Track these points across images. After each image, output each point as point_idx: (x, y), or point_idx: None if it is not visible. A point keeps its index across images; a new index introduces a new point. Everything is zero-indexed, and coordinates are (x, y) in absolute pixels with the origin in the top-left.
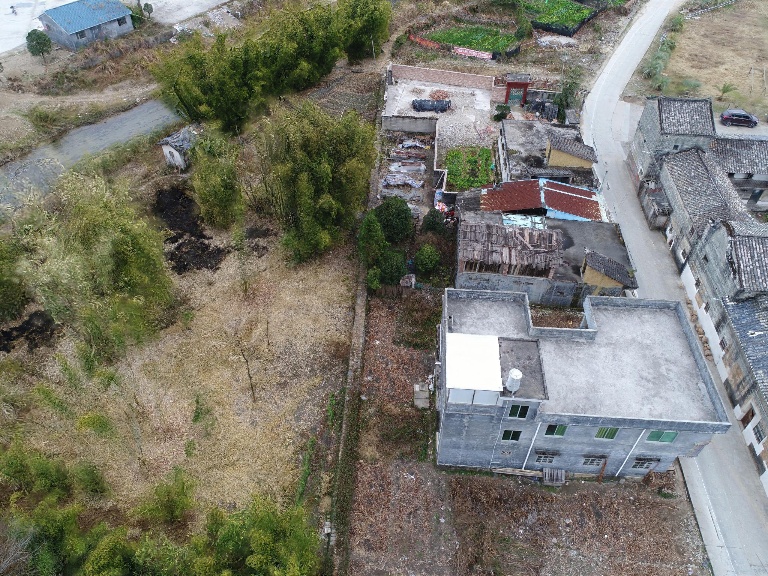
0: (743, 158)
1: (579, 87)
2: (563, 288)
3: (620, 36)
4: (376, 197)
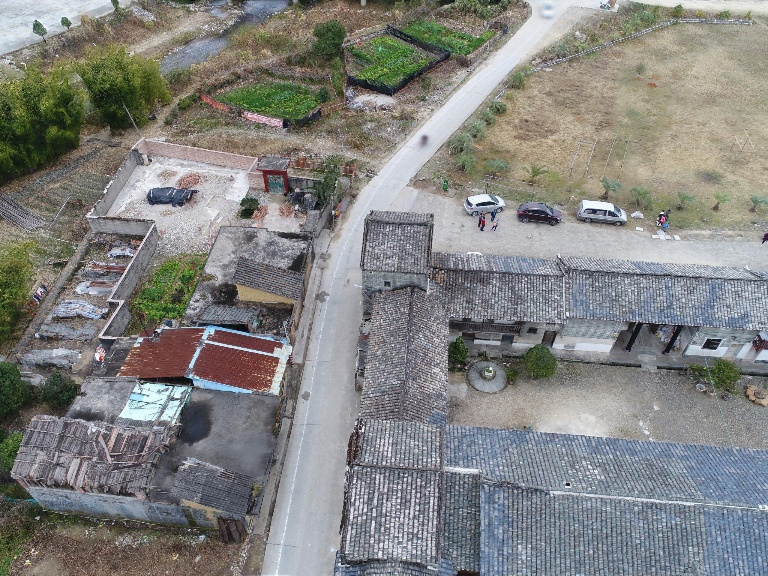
0: (476, 297)
1: (333, 179)
2: (166, 509)
3: (447, 95)
4: (32, 336)
